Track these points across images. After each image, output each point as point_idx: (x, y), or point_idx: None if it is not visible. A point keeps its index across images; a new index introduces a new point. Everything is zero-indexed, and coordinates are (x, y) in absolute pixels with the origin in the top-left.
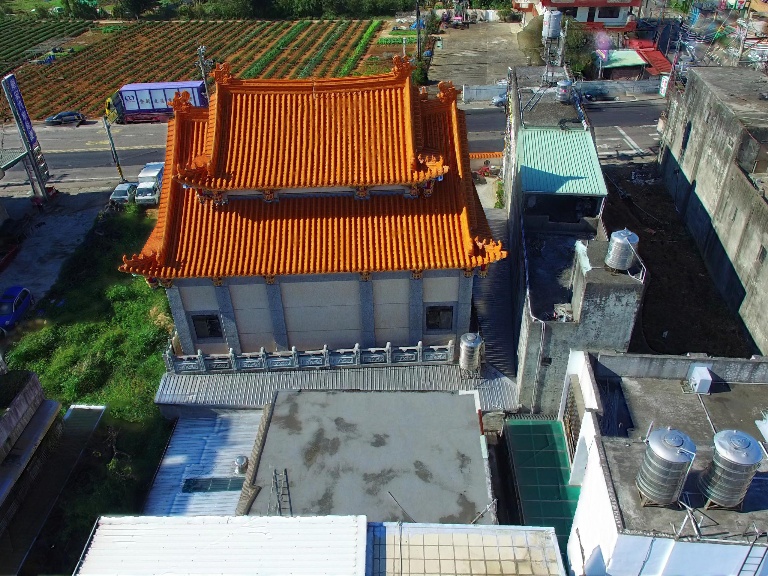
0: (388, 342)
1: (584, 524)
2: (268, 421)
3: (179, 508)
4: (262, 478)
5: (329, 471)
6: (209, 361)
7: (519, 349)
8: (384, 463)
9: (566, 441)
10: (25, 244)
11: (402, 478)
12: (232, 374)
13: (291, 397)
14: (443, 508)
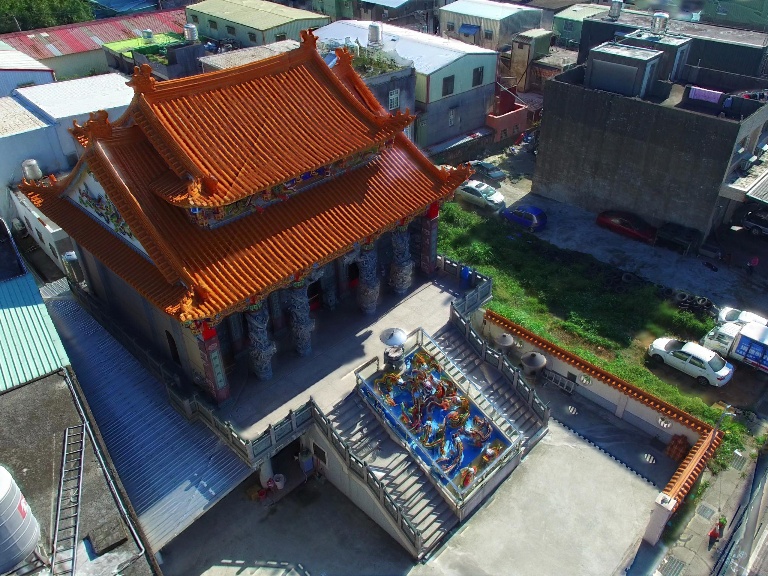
0: None
1: None
2: None
3: None
4: None
5: None
6: None
7: None
8: None
9: None
10: (665, 250)
11: None
12: None
13: None
14: None
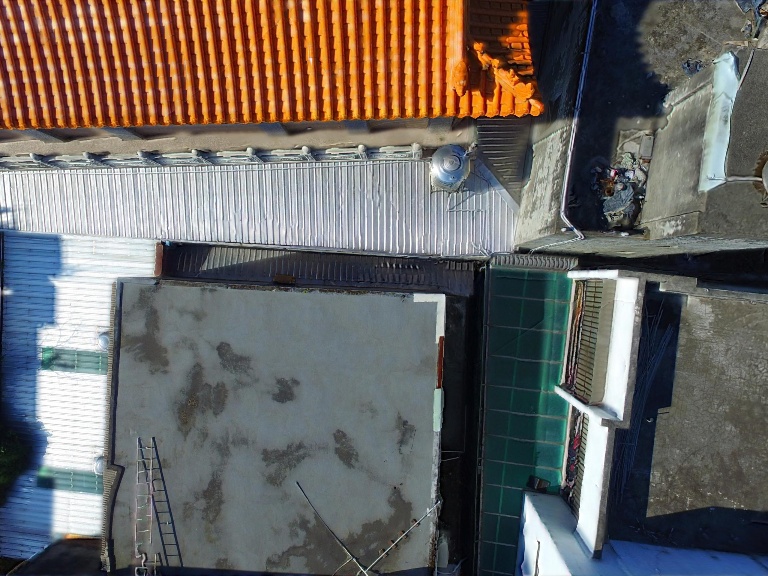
0: (304, 147)
1: (546, 575)
2: (115, 348)
3: (44, 393)
4: (123, 452)
5: (214, 444)
6: (6, 164)
7: (535, 164)
8: (291, 433)
9: (569, 321)
10: None
11: (316, 460)
12: (56, 172)
13: (145, 295)
14: (368, 510)
